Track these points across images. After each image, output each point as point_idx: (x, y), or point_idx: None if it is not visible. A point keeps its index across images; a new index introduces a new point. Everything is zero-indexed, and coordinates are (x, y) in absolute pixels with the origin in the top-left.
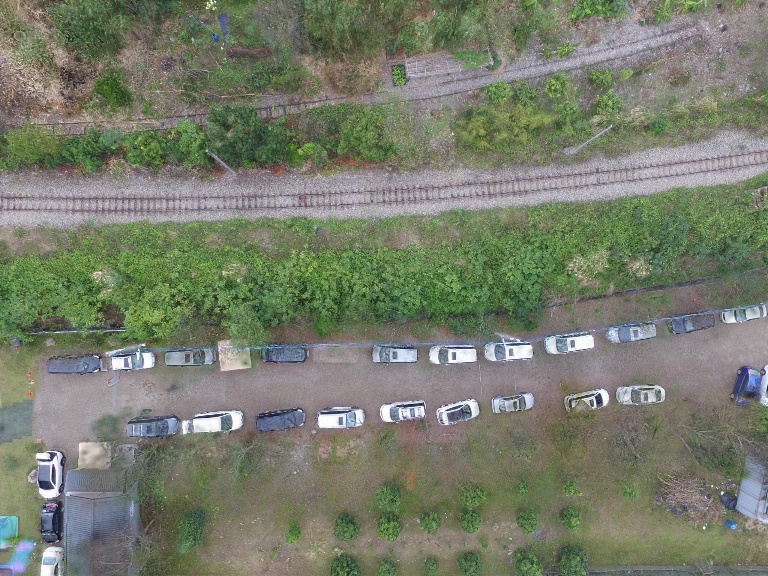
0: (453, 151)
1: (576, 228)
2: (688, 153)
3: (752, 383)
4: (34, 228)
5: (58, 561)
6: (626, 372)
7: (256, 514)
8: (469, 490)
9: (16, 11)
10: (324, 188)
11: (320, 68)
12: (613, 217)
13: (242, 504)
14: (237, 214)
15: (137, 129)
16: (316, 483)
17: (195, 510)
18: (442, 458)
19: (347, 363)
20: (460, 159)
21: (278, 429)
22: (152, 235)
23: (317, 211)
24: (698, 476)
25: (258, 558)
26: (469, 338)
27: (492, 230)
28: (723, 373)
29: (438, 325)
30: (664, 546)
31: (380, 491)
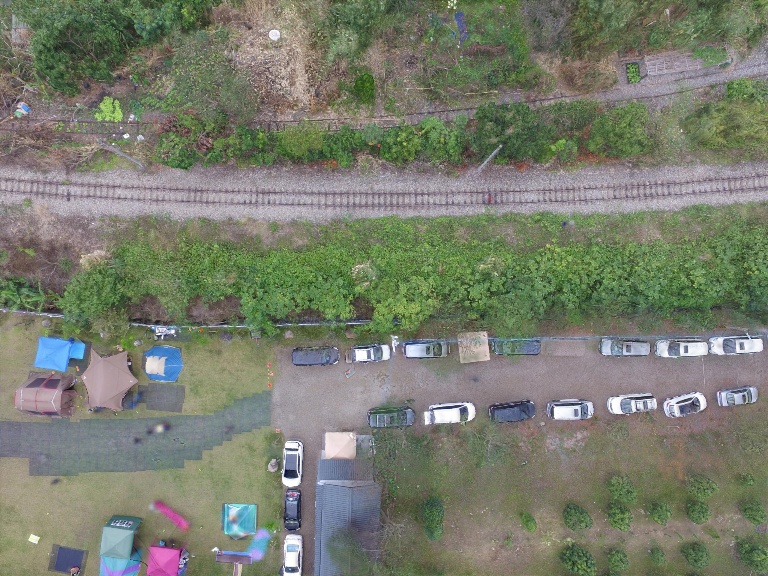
0: (685, 148)
1: None
2: None
3: None
4: (288, 222)
5: (300, 548)
6: None
7: (485, 504)
8: (701, 482)
9: (261, 10)
10: (568, 184)
11: (555, 66)
12: None
13: (472, 494)
14: (484, 209)
15: (379, 126)
16: (543, 474)
17: (427, 500)
18: (665, 450)
19: (574, 356)
20: (696, 155)
21: (515, 420)
22: (401, 229)
23: (562, 206)
24: None
25: (489, 547)
26: (696, 332)
27: (734, 225)
28: None
29: (663, 319)
30: None
31: (616, 482)
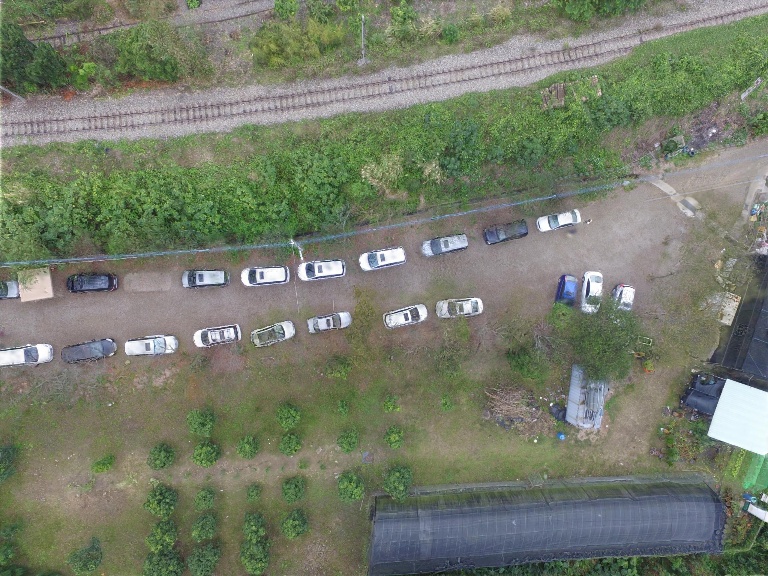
0: None
1: (369, 137)
2: (479, 58)
3: (569, 289)
4: None
5: None
6: (446, 286)
7: (72, 450)
8: (283, 411)
9: None
10: (114, 110)
11: None
12: (405, 123)
13: (56, 440)
14: (26, 140)
15: None
16: (132, 415)
17: None
18: (262, 383)
19: (159, 291)
20: (256, 77)
21: (83, 358)
22: None
23: (107, 133)
24: (525, 388)
25: (73, 494)
26: (280, 258)
27: (286, 143)
28: (544, 283)
29: (251, 248)
30: (496, 462)
31: (190, 416)
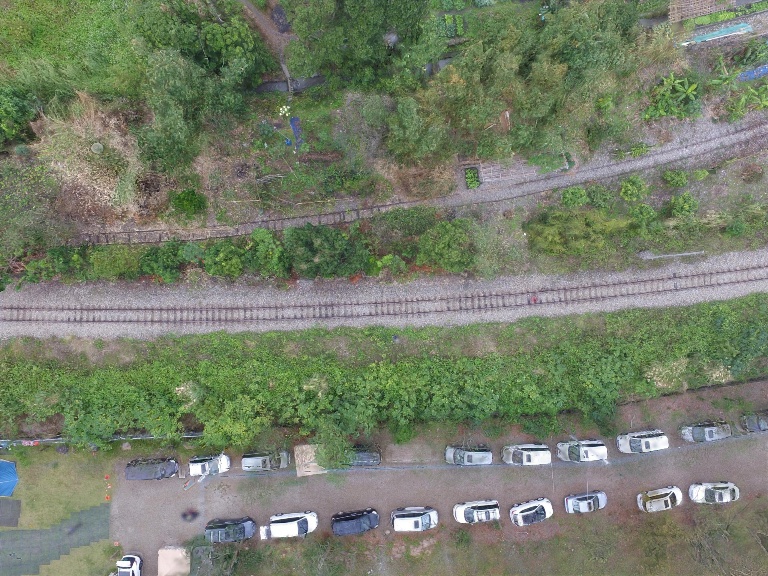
0: (526, 253)
1: (654, 335)
2: (766, 257)
3: None
4: (113, 339)
5: None
6: (698, 469)
7: None
8: None
9: (90, 119)
10: (401, 296)
11: (393, 171)
12: (692, 324)
13: None
14: (314, 323)
15: (212, 236)
16: None
17: None
18: (514, 556)
19: (419, 463)
20: (535, 263)
21: (354, 533)
22: (230, 345)
23: (394, 319)
24: None
25: None
26: (542, 438)
27: (569, 337)
28: None
29: (510, 424)
30: None
31: None
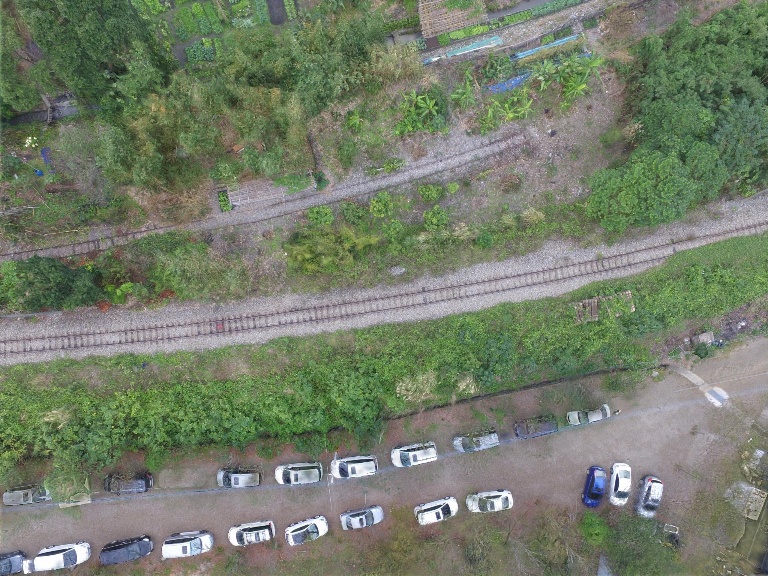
0: (285, 273)
1: (404, 349)
2: (513, 267)
3: (598, 485)
4: None
5: None
6: (476, 478)
7: None
8: None
9: None
10: (150, 322)
11: (147, 197)
12: (439, 337)
13: None
14: (63, 354)
15: None
16: None
17: None
18: (295, 575)
19: (194, 487)
20: (290, 282)
21: None
22: None
23: (144, 346)
24: None
25: None
26: (313, 456)
27: (321, 355)
28: (573, 473)
29: (284, 443)
30: None
31: None
